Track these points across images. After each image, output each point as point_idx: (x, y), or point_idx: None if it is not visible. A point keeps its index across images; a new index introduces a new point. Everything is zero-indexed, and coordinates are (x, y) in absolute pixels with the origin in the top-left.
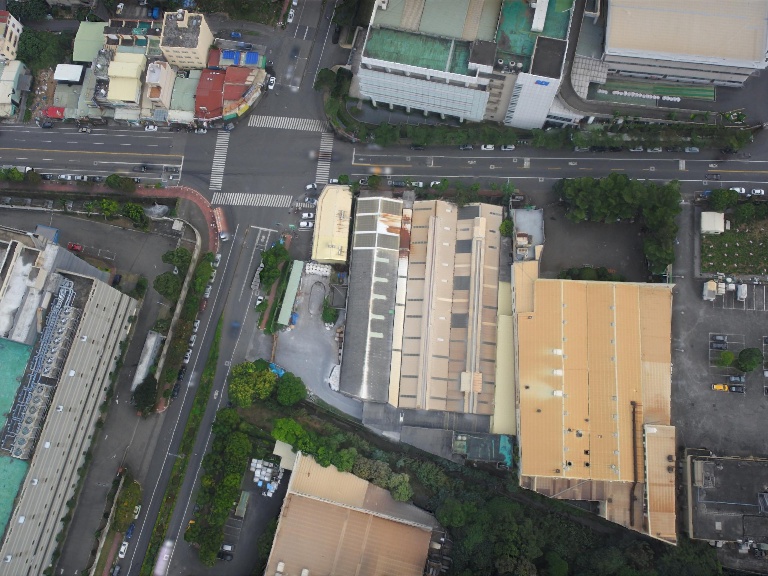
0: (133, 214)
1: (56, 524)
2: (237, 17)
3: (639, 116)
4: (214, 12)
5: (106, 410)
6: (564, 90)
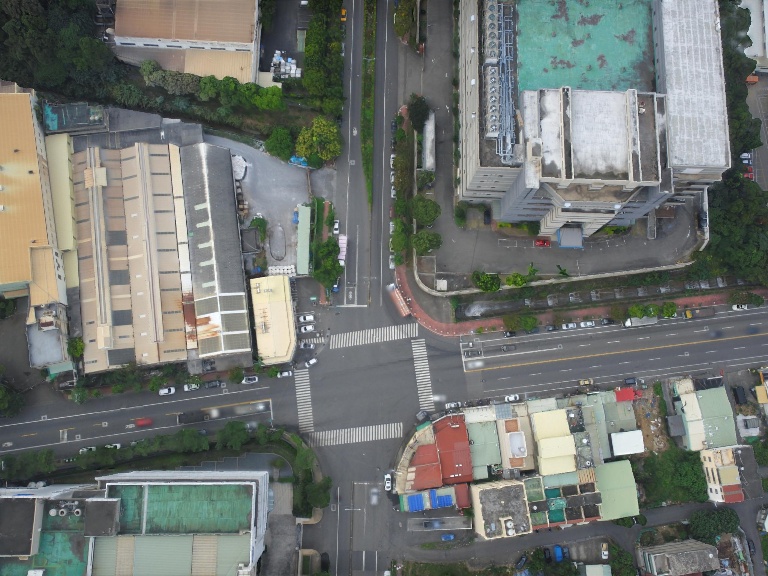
0: (486, 277)
1: None
2: (456, 567)
3: None
4: (487, 569)
5: None
6: None
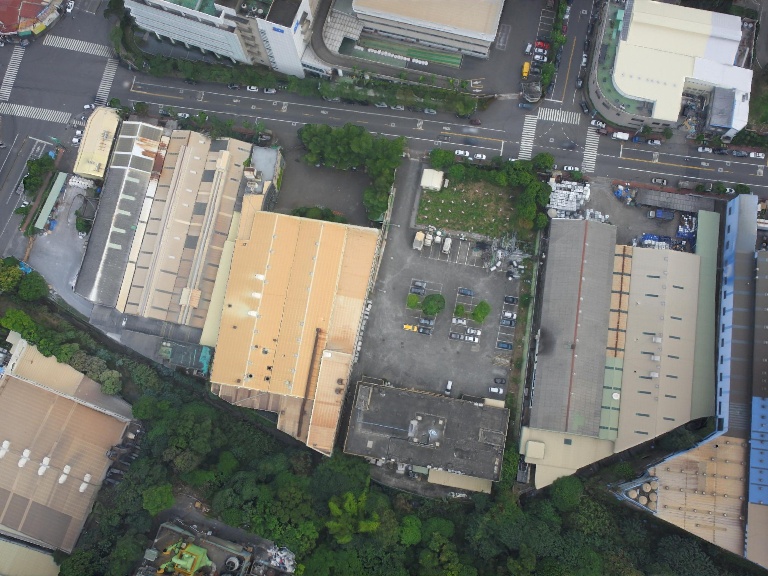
0: None
1: None
2: None
3: (383, 74)
4: None
5: None
6: (316, 41)
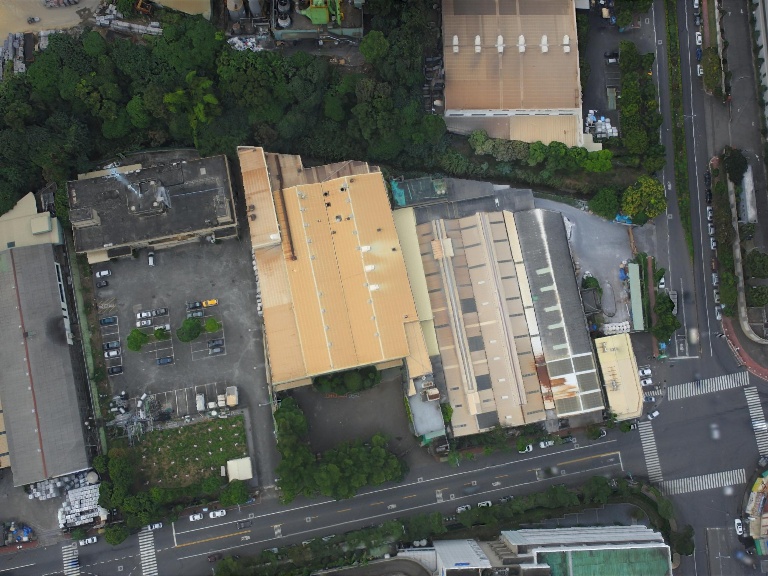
0: None
1: (766, 40)
2: None
3: (337, 573)
4: None
5: (764, 145)
6: None
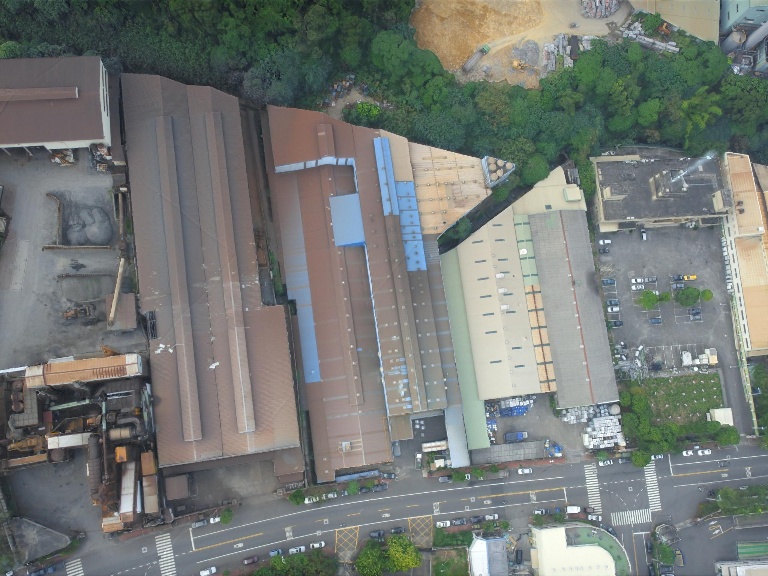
0: None
1: None
2: None
3: None
4: None
5: None
6: None
